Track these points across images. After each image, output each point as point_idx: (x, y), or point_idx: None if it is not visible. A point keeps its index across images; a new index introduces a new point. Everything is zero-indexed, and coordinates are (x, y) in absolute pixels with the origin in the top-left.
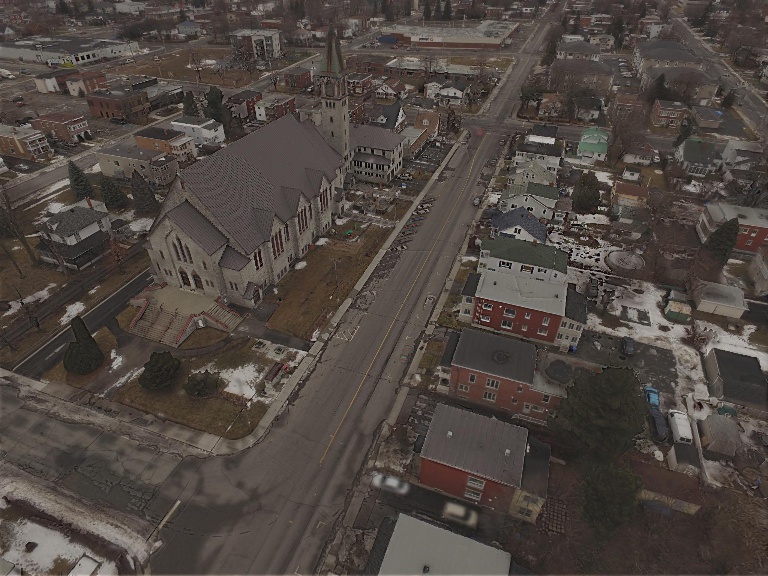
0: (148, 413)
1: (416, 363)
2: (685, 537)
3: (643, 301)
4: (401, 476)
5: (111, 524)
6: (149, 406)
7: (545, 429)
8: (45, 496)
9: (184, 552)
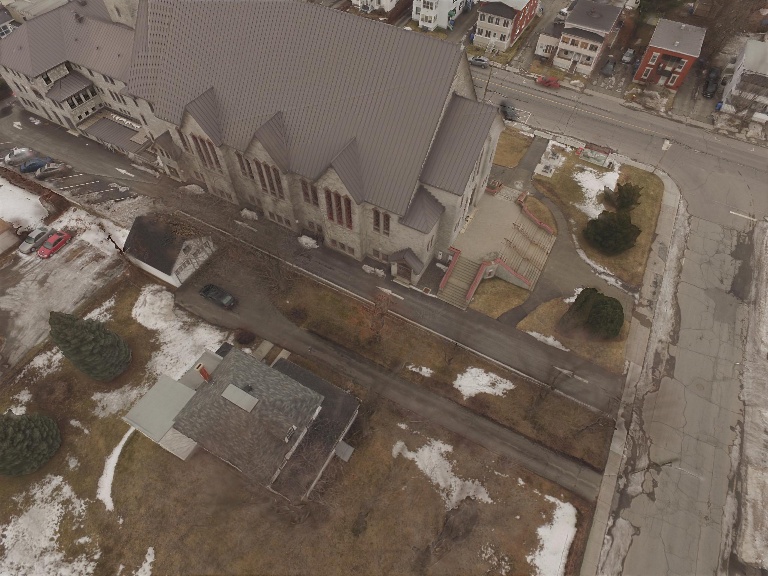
0: (651, 249)
1: None
2: (675, 18)
3: None
4: (671, 100)
5: (767, 250)
6: (644, 248)
7: (617, 39)
8: (764, 307)
9: (767, 203)
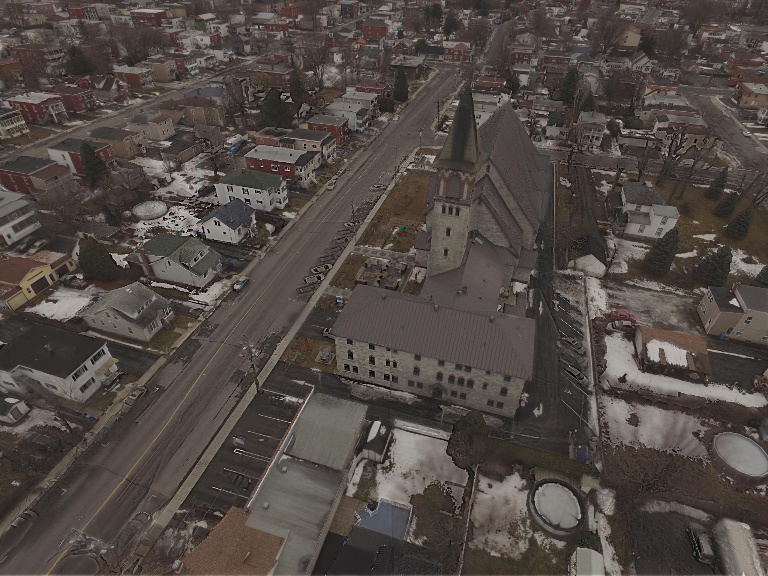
0: None
1: (346, 165)
2: None
3: (178, 185)
4: None
5: None
6: None
7: None
8: None
9: None
